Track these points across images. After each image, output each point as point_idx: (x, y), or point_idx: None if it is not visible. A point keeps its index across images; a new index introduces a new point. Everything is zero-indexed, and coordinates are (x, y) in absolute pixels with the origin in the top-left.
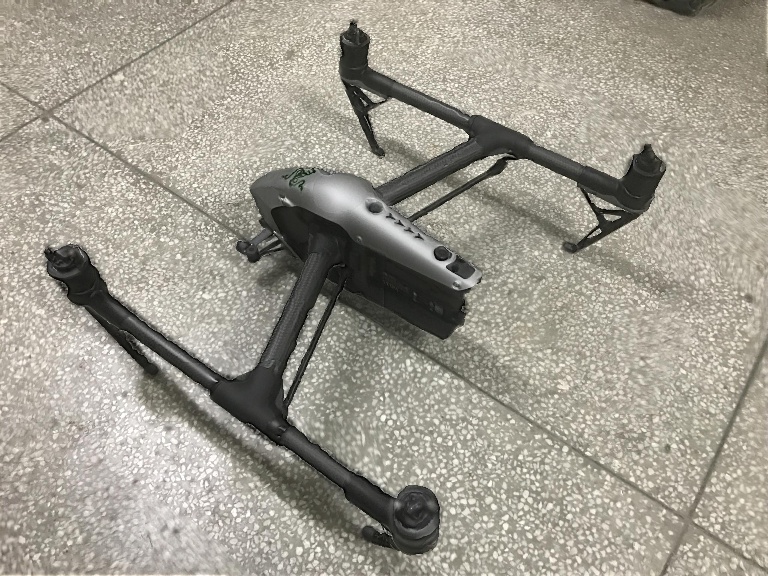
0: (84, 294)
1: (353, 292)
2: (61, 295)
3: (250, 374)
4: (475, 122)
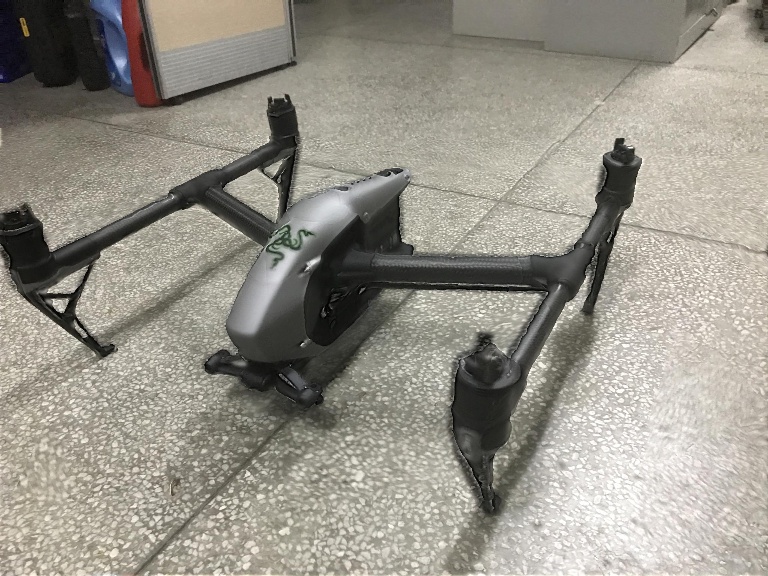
0: None
1: (367, 306)
2: None
3: (540, 269)
4: (181, 191)
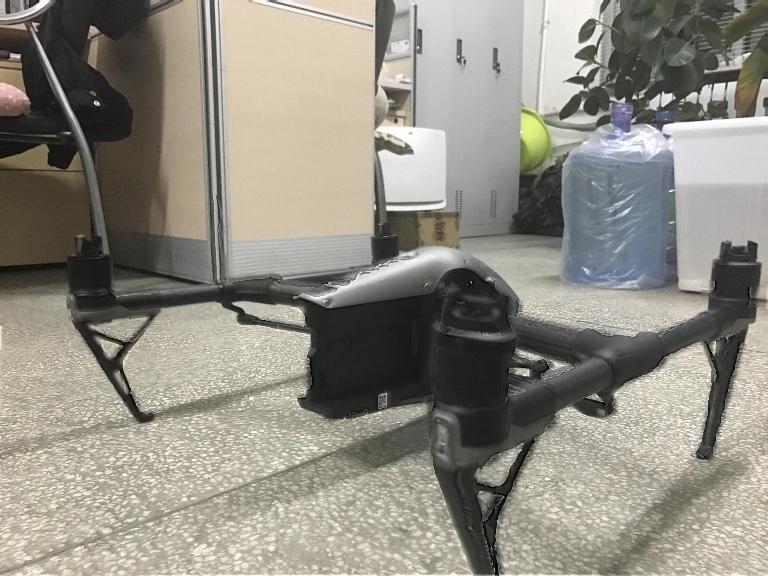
0: None
1: None
2: None
3: None
4: None
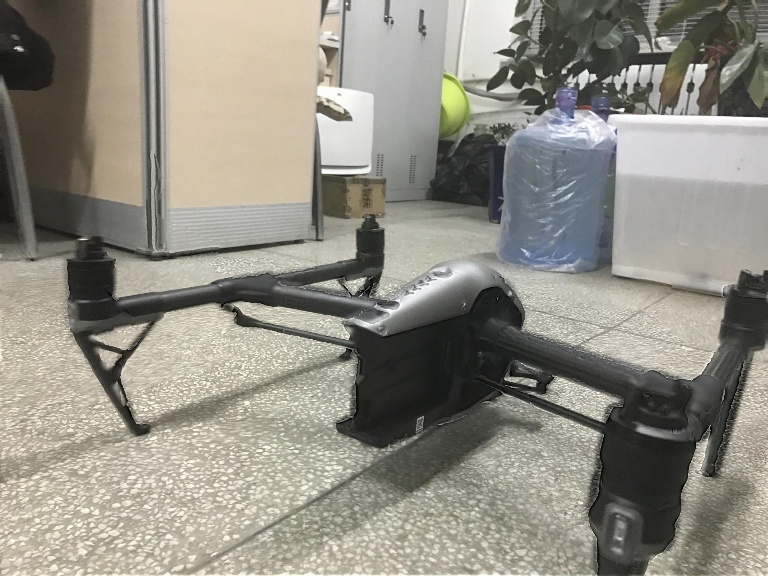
0: None
1: None
2: None
3: None
4: (698, 378)
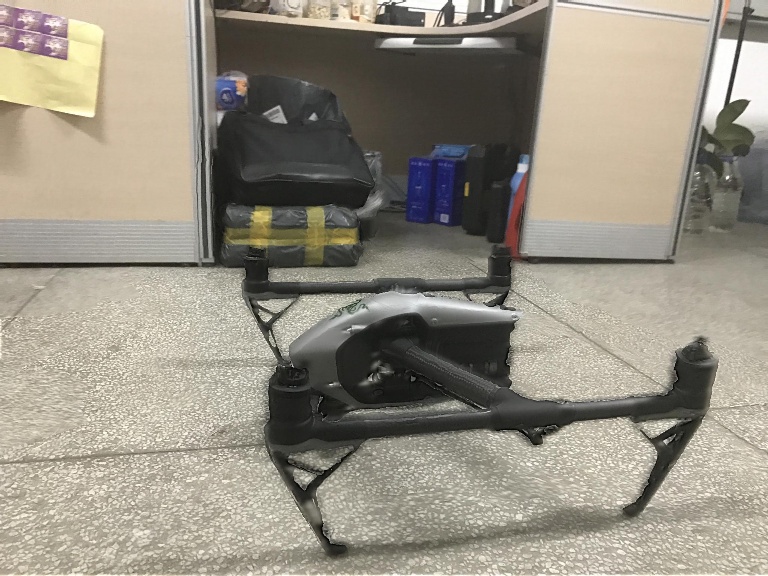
0: (309, 422)
1: (422, 399)
2: (143, 571)
3: (498, 398)
4: (380, 281)
